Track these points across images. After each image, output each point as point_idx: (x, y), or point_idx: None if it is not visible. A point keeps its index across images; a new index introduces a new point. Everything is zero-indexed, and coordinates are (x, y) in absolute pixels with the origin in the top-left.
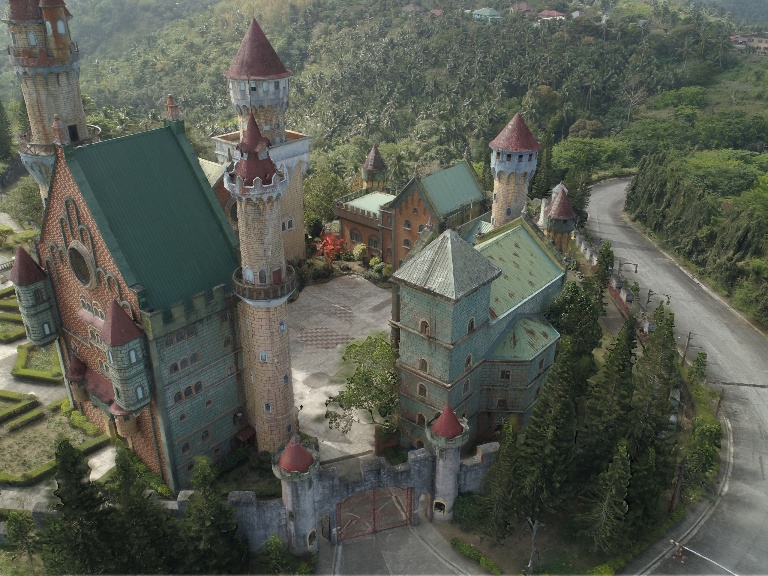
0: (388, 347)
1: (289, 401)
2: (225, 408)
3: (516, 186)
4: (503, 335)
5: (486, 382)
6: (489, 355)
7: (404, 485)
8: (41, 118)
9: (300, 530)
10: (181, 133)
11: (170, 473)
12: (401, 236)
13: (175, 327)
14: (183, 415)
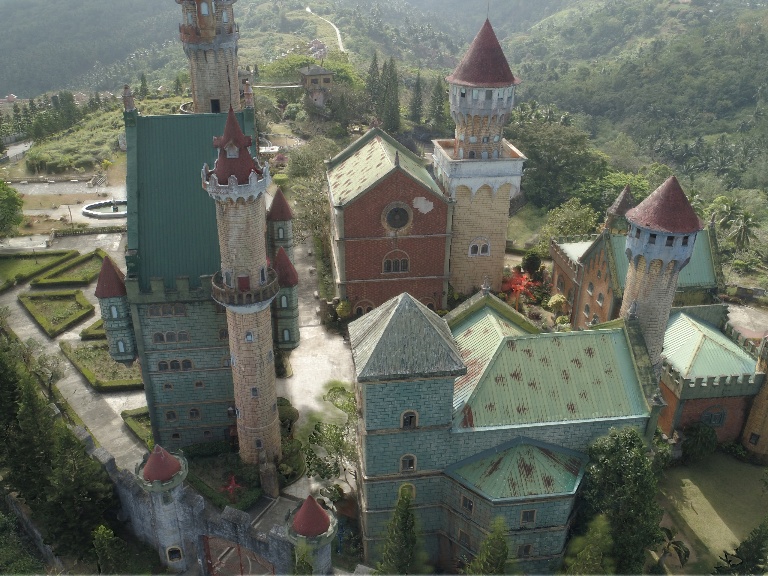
0: (356, 405)
1: (260, 416)
2: (220, 396)
3: (647, 275)
4: (487, 454)
5: (448, 500)
6: (452, 469)
7: (264, 557)
8: (194, 89)
9: (160, 539)
10: (250, 121)
11: (152, 431)
12: (584, 299)
13: (153, 299)
14: (170, 384)
